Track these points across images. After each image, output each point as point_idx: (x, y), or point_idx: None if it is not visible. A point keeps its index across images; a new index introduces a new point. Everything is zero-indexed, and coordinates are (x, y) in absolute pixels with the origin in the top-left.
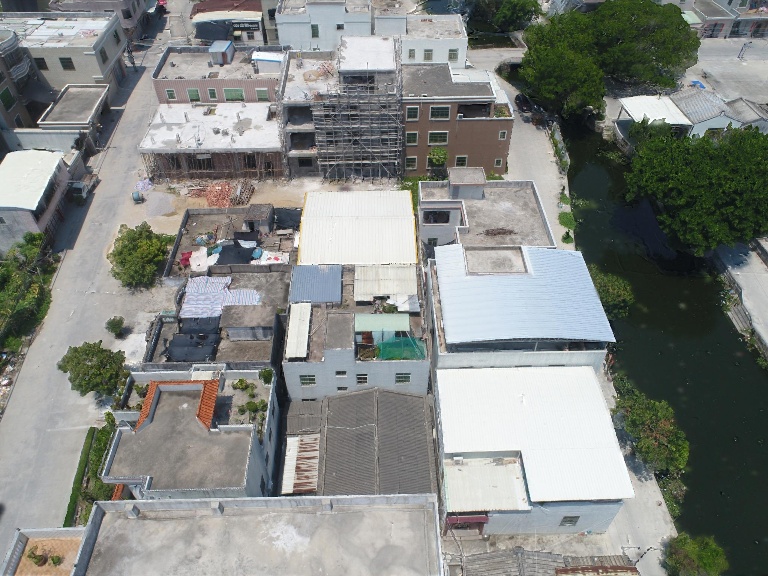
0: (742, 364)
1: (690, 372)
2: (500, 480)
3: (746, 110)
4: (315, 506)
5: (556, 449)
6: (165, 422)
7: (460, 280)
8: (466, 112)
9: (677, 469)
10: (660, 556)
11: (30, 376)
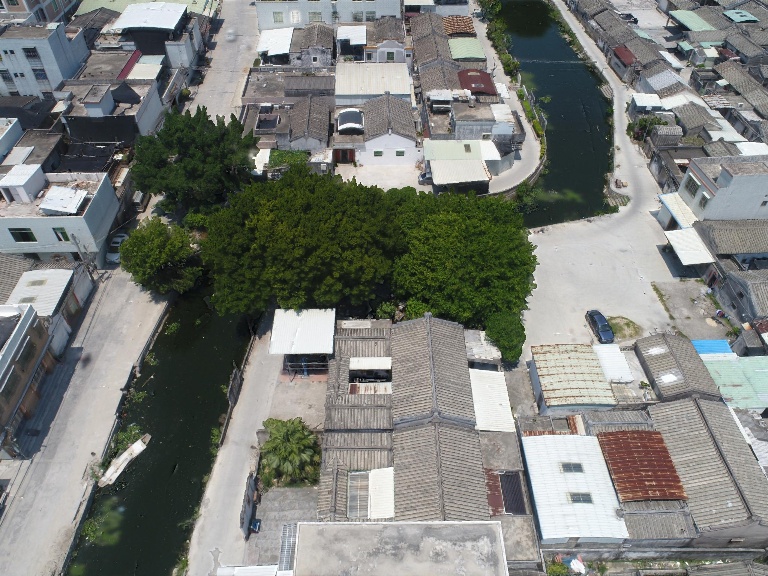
0: (541, 8)
1: None
2: (425, 0)
3: None
4: None
5: None
6: None
7: None
8: None
9: None
10: (486, 35)
11: (228, 4)
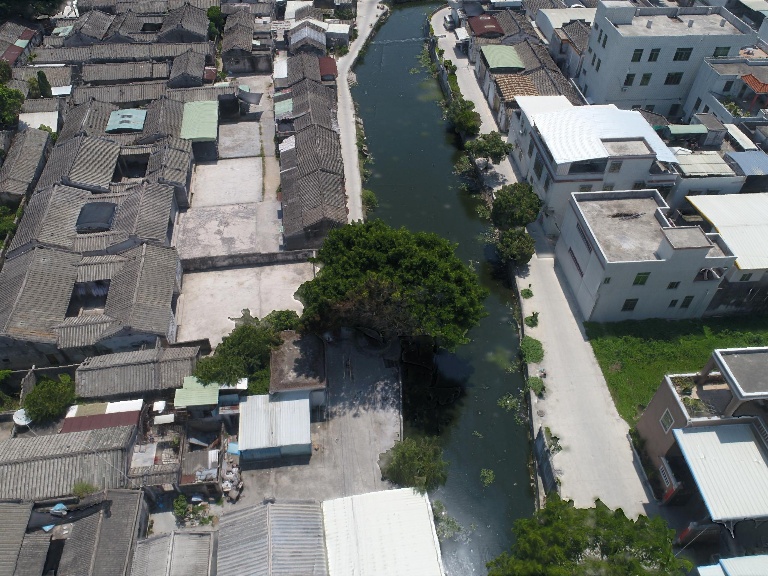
0: None
1: (430, 221)
2: None
3: (180, 573)
4: (670, 43)
5: (555, 106)
6: (766, 80)
7: (647, 138)
8: (751, 414)
9: (457, 173)
10: None
11: None
